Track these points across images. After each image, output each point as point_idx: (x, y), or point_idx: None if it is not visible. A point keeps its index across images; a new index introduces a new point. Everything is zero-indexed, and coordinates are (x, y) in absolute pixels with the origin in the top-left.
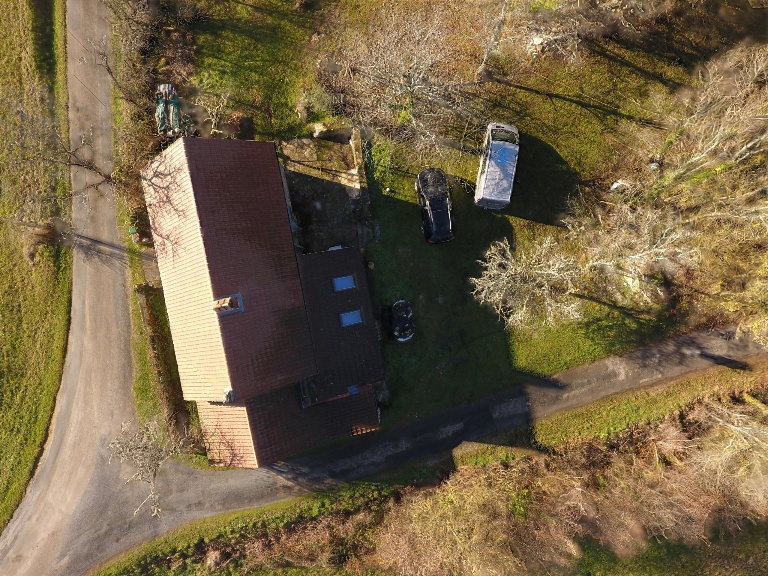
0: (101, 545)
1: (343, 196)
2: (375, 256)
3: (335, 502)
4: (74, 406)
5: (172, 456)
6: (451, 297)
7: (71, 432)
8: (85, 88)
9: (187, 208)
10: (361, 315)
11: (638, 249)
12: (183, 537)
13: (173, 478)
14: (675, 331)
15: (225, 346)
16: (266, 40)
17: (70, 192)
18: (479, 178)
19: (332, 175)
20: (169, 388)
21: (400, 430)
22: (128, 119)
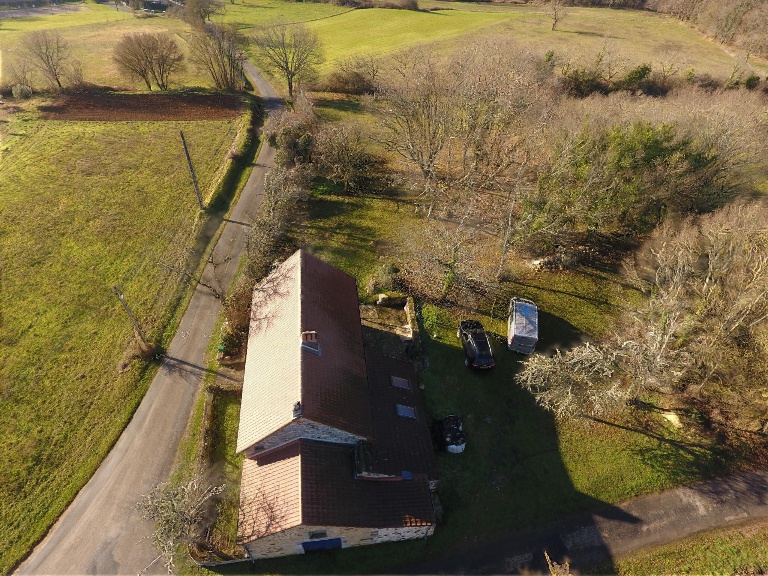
0: None
1: (397, 342)
2: (425, 380)
3: None
4: (93, 502)
5: (179, 572)
6: (499, 418)
7: (75, 532)
8: None
9: (292, 287)
10: (415, 413)
11: (665, 392)
12: None
13: None
14: (737, 466)
15: (302, 370)
16: (348, 256)
17: (176, 330)
18: (509, 328)
19: (389, 328)
20: (206, 482)
21: (457, 557)
22: None
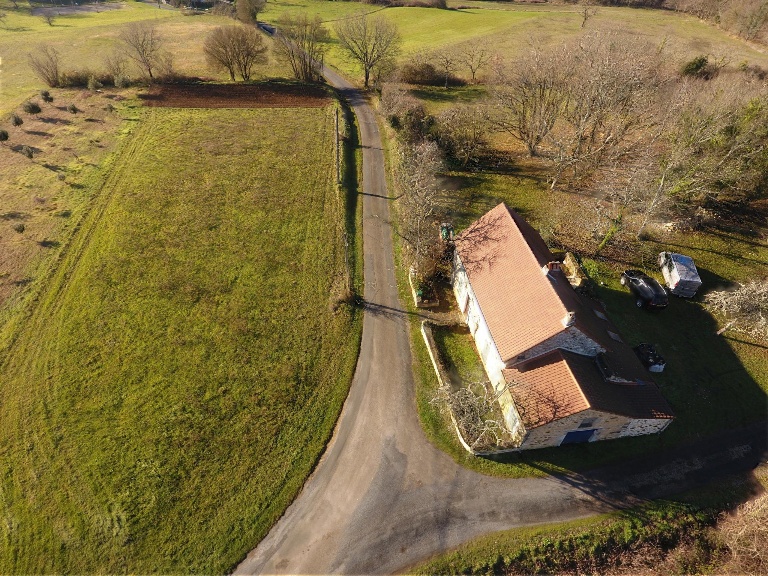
0: (384, 554)
1: None
2: None
3: (647, 523)
4: (360, 412)
5: (459, 460)
6: (682, 347)
7: (355, 433)
8: (374, 239)
9: (508, 232)
10: None
11: None
12: (480, 552)
13: (461, 483)
14: None
15: (557, 292)
16: None
17: (363, 282)
18: (669, 276)
19: None
20: None
21: (688, 448)
22: (409, 247)
